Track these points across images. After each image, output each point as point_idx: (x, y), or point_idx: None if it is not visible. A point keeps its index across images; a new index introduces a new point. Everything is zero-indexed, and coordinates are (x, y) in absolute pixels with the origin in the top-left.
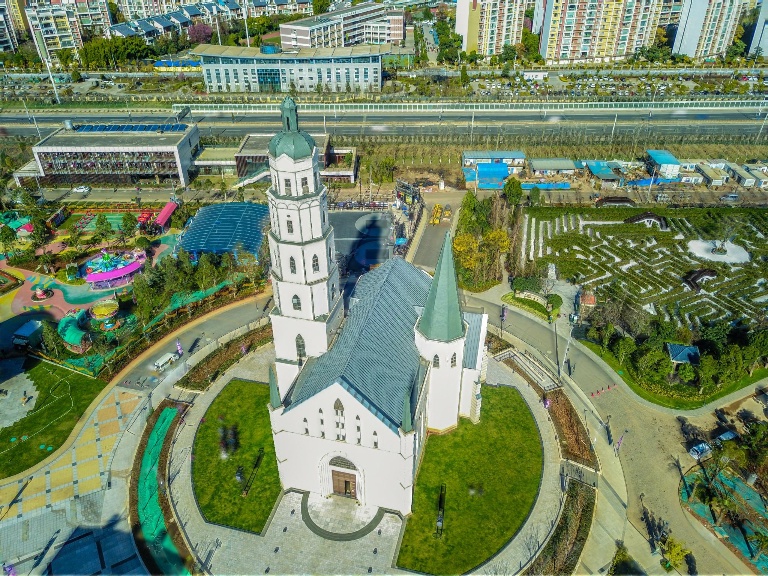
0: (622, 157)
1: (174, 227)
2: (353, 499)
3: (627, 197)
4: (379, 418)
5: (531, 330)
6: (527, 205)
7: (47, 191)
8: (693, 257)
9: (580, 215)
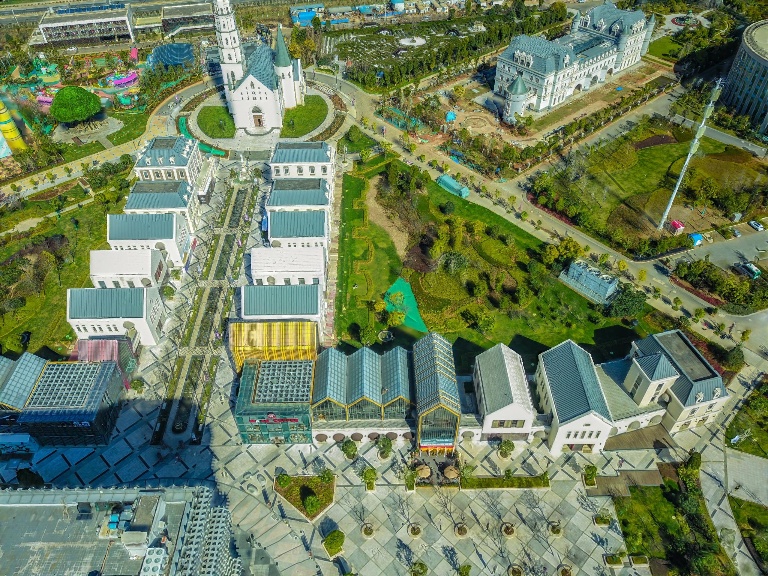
0: (379, 3)
1: (141, 60)
2: (262, 127)
3: (375, 22)
4: (266, 86)
5: (326, 79)
6: (326, 31)
7: (51, 52)
8: (400, 45)
9: (352, 33)
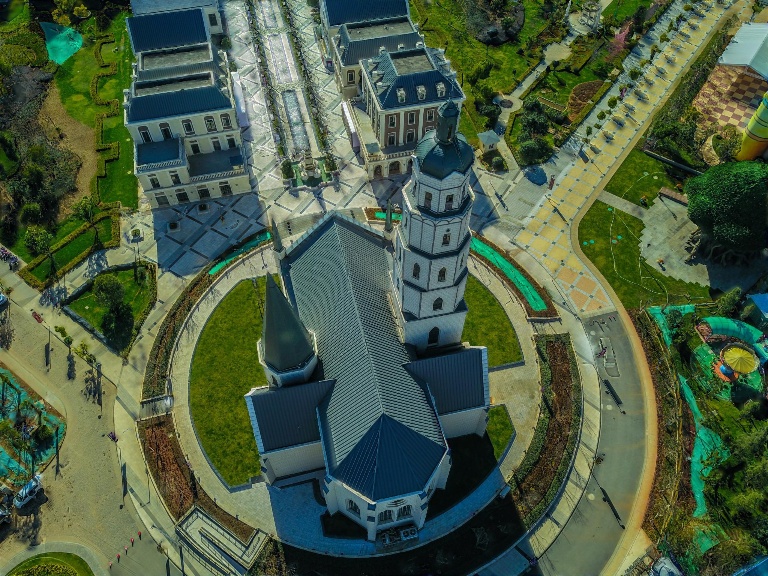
0: None
1: None
2: None
3: None
4: None
5: None
6: None
7: None
8: None
9: None
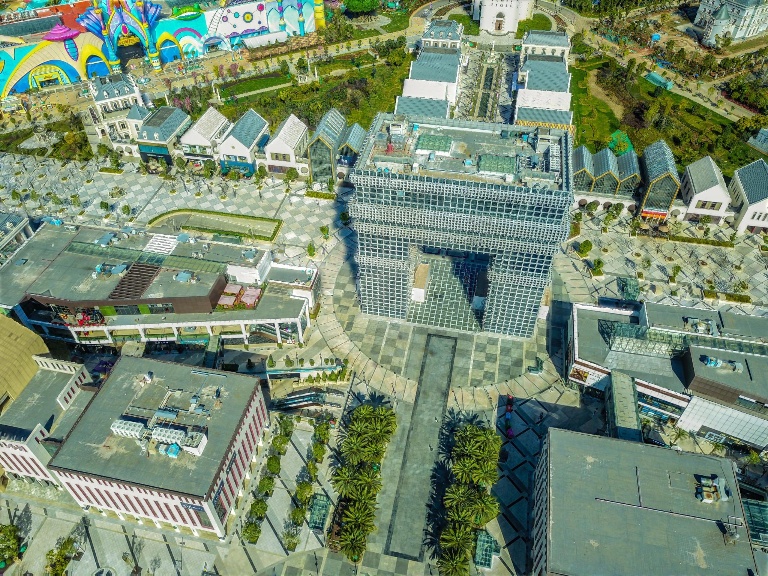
0: None
1: None
2: (500, 30)
3: None
4: None
5: (547, 4)
6: None
7: None
8: None
9: None
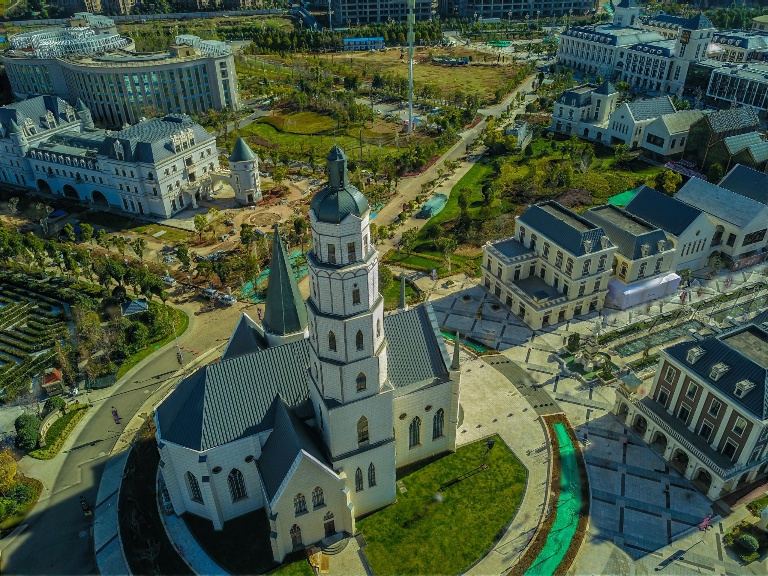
0: None
1: None
2: None
3: None
4: None
5: None
6: None
7: None
8: None
9: None
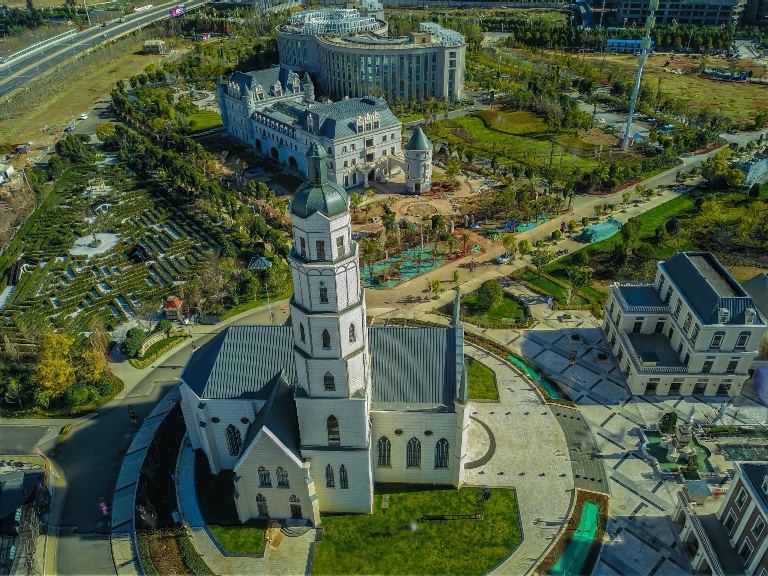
0: None
1: None
2: None
3: None
4: None
5: None
6: None
7: None
8: (102, 255)
9: None
